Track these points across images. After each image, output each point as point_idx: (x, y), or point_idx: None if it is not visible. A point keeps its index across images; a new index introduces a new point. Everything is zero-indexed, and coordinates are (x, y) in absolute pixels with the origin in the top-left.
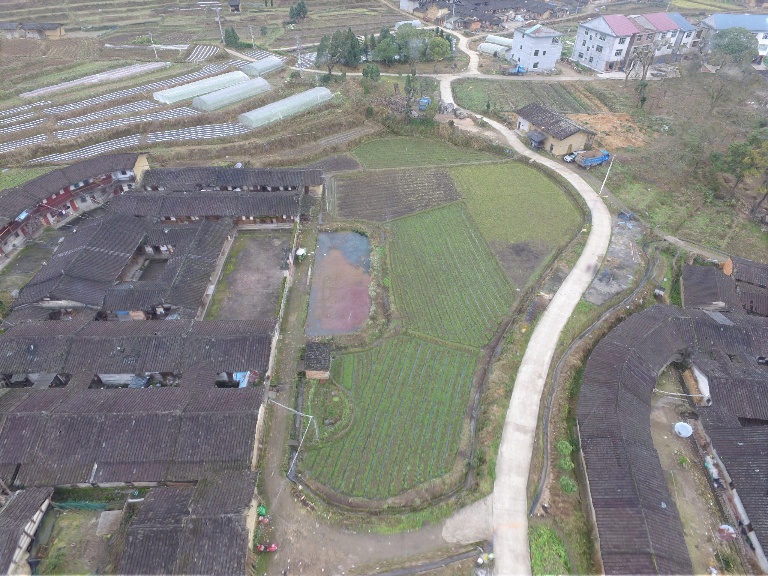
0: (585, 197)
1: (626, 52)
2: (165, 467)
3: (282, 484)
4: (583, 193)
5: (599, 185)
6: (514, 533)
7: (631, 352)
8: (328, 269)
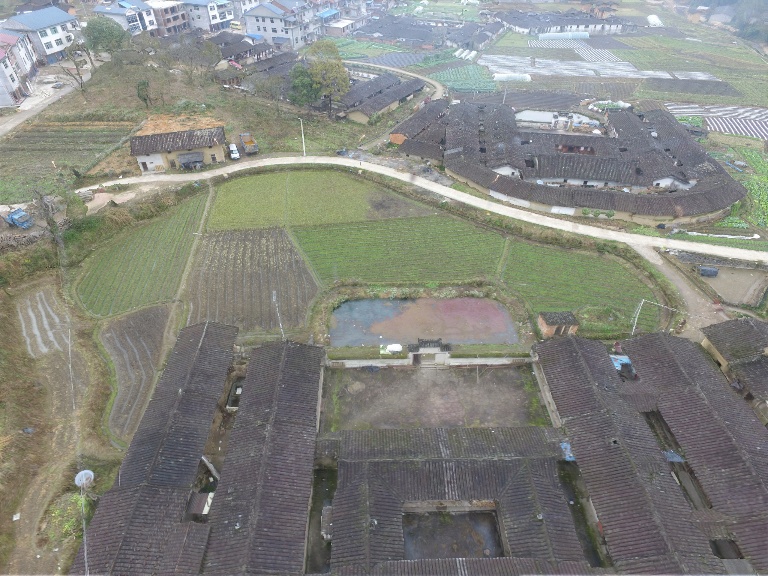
0: (309, 162)
1: (16, 75)
2: (734, 397)
3: None
4: (301, 162)
5: (285, 154)
6: (643, 239)
7: (504, 177)
8: (410, 332)
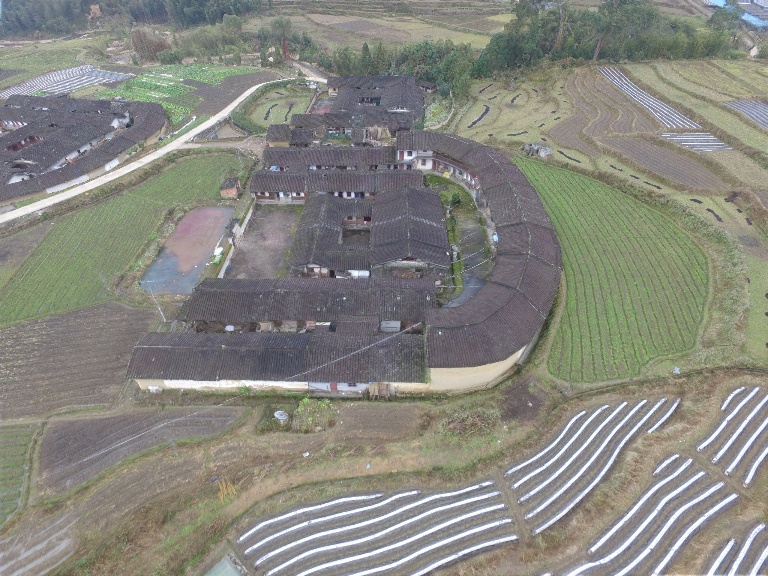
0: None
1: None
2: None
3: (261, 158)
4: None
5: None
6: (174, 143)
7: None
8: (199, 252)
